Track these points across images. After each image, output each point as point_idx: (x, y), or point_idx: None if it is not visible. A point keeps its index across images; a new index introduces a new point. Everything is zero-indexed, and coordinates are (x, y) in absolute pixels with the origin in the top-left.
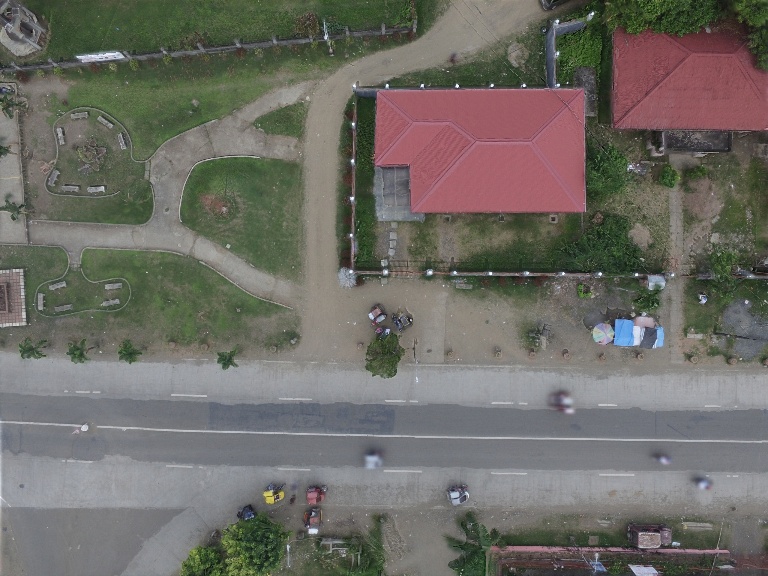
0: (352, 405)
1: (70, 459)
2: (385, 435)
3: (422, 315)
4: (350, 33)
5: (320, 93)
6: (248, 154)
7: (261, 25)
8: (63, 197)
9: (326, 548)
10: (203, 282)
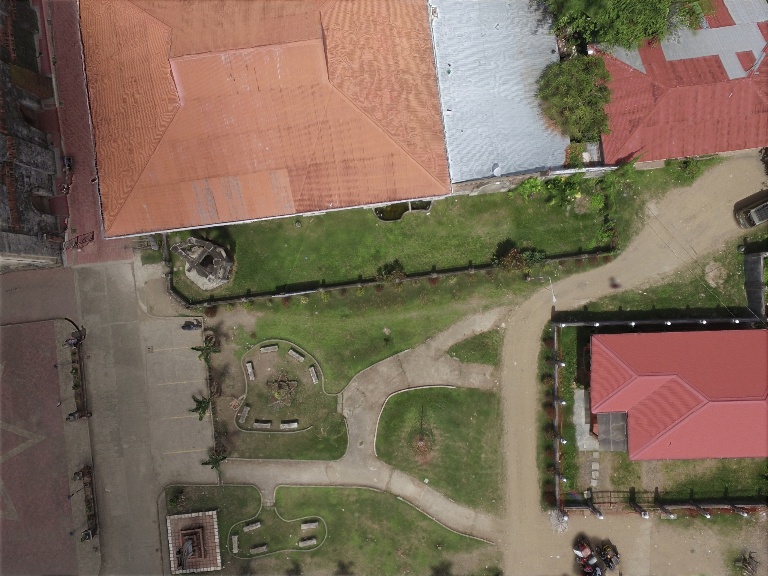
0: None
1: None
2: None
3: (626, 546)
4: (549, 261)
5: (516, 319)
6: (443, 384)
7: (453, 250)
8: (254, 433)
9: None
10: (401, 518)
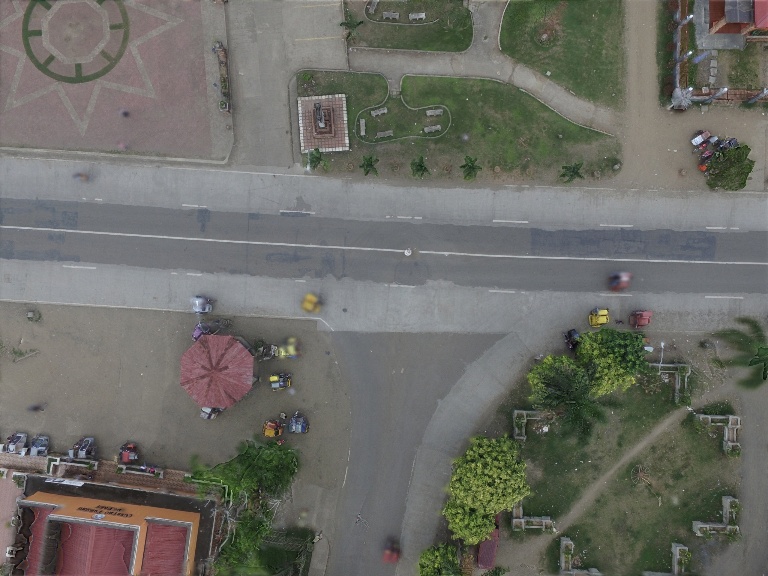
0: (673, 232)
1: (393, 284)
2: (706, 261)
3: (742, 143)
4: None
5: None
6: None
7: None
8: (382, 24)
9: (656, 369)
10: (523, 109)
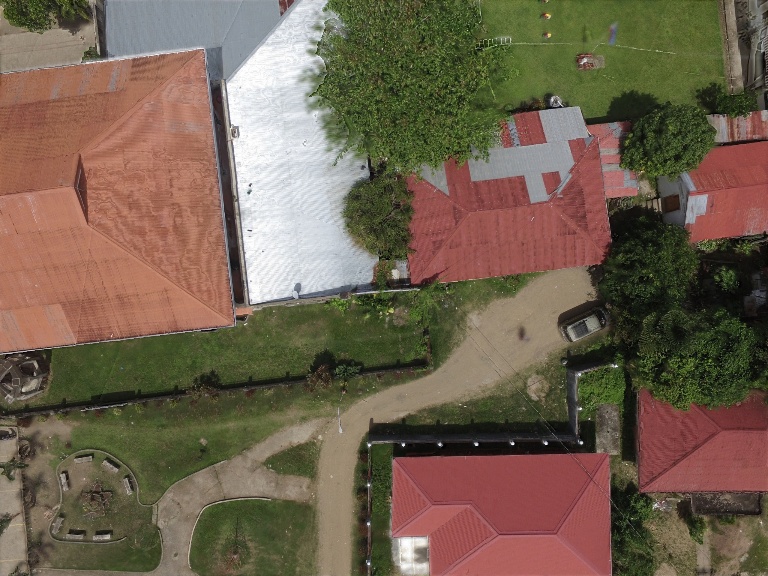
0: None
1: None
2: None
3: None
4: (363, 375)
5: (333, 432)
6: (259, 496)
7: (271, 362)
8: (68, 544)
9: None
10: None
